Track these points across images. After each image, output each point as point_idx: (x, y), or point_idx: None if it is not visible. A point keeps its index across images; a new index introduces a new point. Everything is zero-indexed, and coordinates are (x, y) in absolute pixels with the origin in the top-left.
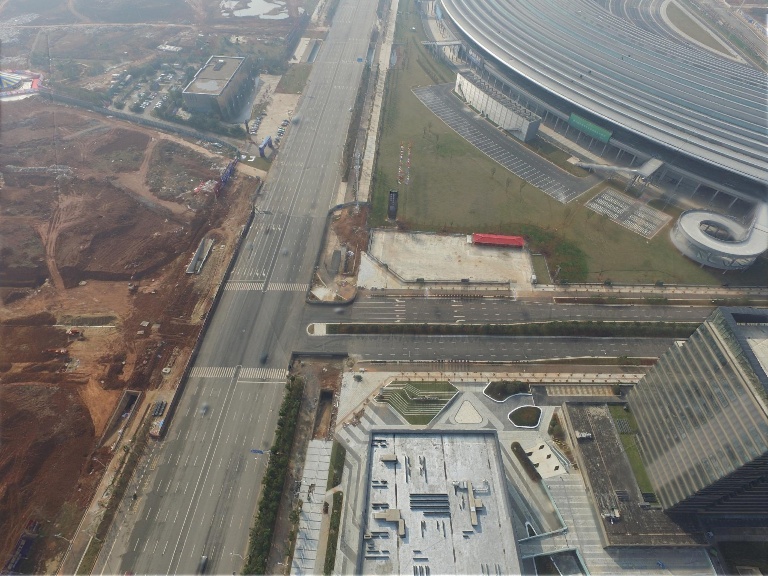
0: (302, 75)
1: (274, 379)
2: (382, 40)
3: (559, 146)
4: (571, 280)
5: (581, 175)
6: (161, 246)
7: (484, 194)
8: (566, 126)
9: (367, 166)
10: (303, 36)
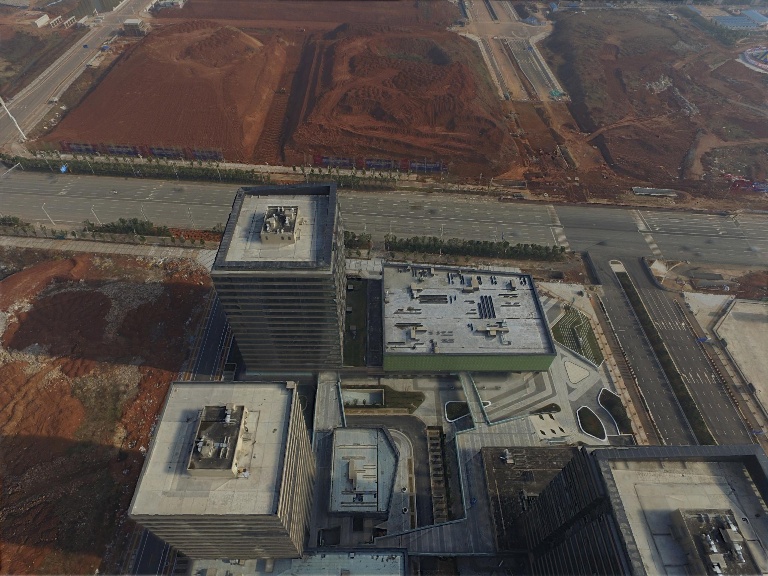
0: None
1: (560, 245)
2: None
3: None
4: None
5: None
6: (650, 170)
7: None
8: None
9: None
10: None
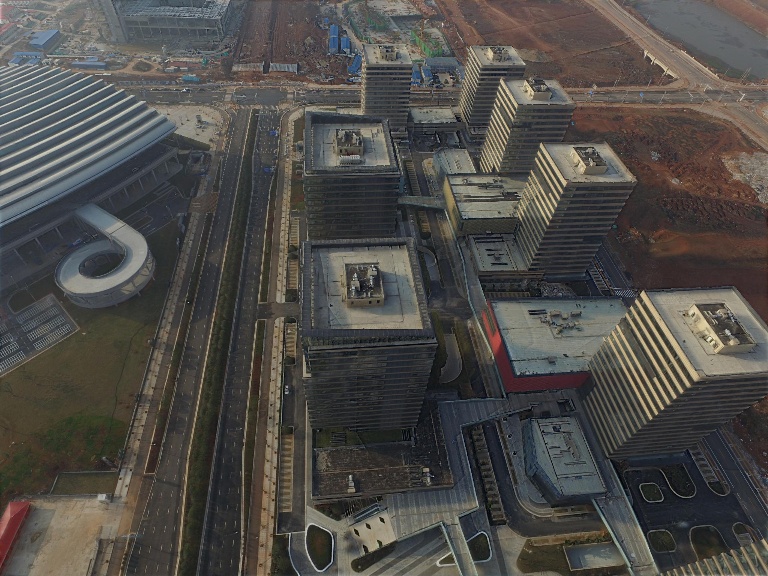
0: None
1: None
2: None
3: None
4: (120, 443)
5: None
6: None
7: None
8: None
9: None
10: None
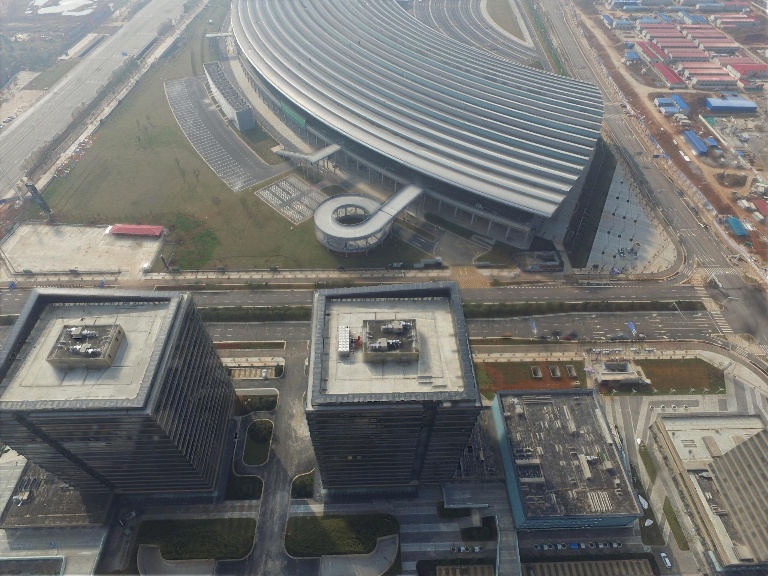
0: (62, 71)
1: None
2: (170, 34)
3: (273, 135)
4: (186, 268)
5: (273, 163)
6: None
7: (160, 185)
8: None
9: (62, 160)
10: (92, 32)
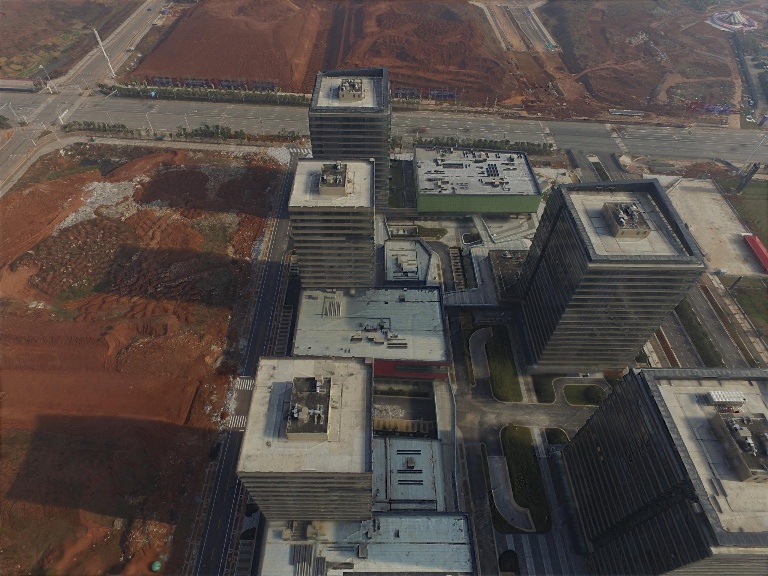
0: None
1: None
2: None
3: None
4: (742, 303)
5: None
6: (624, 98)
7: None
8: None
9: None
10: None
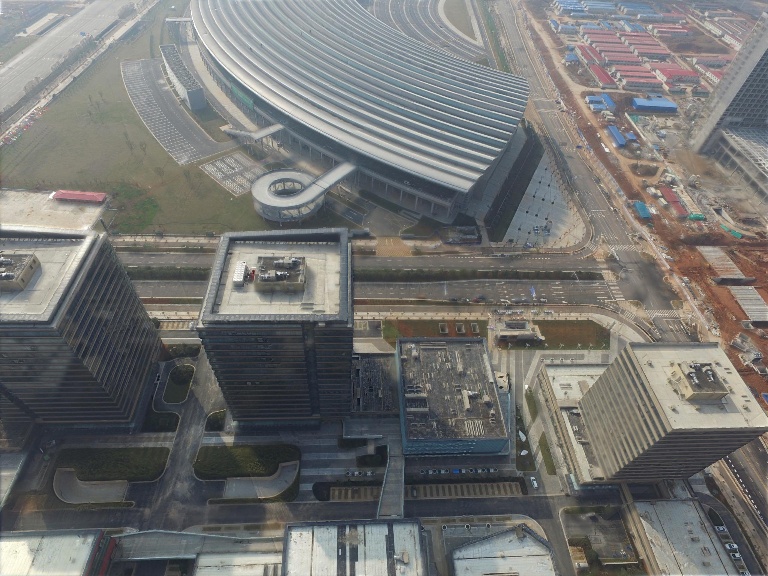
0: (19, 47)
1: None
2: (131, 17)
3: (224, 115)
4: (125, 231)
5: (221, 140)
6: None
7: (107, 156)
8: (234, 96)
9: None
10: (52, 12)
